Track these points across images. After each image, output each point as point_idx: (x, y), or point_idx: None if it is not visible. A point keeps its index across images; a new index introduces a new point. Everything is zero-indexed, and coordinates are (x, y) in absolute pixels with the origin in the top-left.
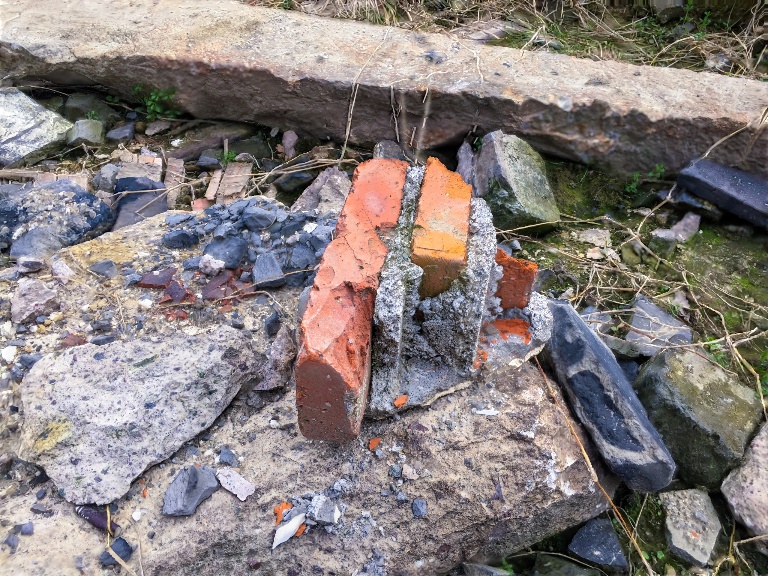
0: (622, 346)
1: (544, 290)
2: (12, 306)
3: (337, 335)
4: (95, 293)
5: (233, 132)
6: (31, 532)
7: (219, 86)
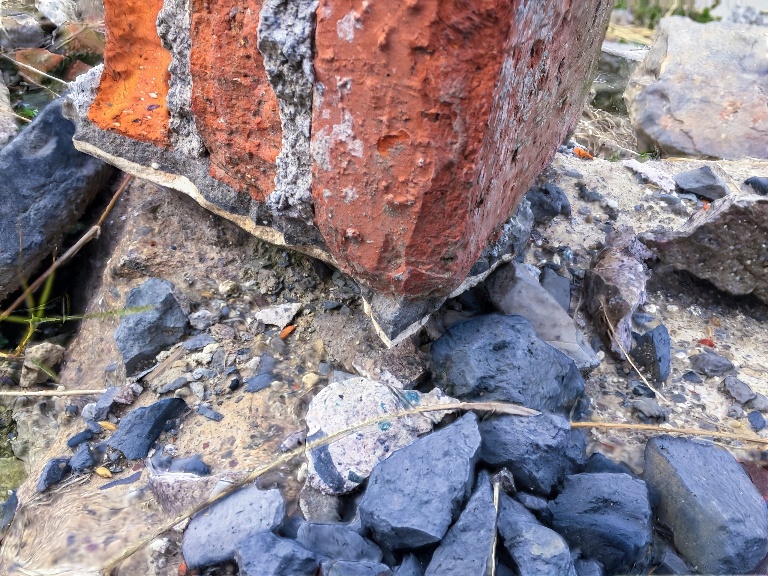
0: None
1: None
2: None
3: None
4: None
5: None
6: None
7: None
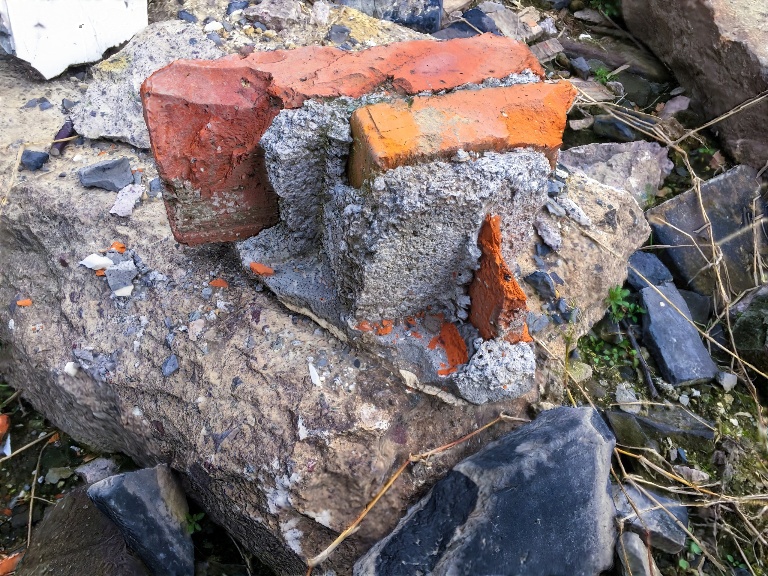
0: (635, 571)
1: (677, 443)
2: (259, 4)
3: (191, 99)
4: (305, 38)
5: (643, 65)
6: (43, 109)
7: (661, 2)
